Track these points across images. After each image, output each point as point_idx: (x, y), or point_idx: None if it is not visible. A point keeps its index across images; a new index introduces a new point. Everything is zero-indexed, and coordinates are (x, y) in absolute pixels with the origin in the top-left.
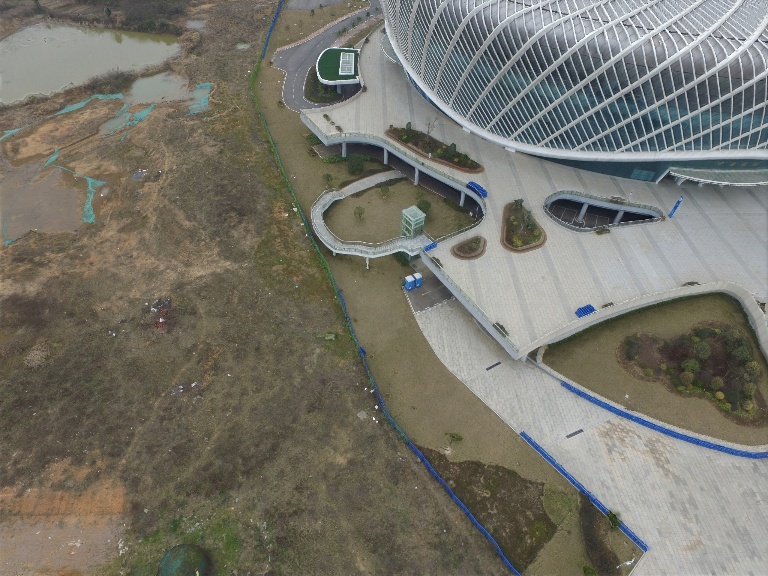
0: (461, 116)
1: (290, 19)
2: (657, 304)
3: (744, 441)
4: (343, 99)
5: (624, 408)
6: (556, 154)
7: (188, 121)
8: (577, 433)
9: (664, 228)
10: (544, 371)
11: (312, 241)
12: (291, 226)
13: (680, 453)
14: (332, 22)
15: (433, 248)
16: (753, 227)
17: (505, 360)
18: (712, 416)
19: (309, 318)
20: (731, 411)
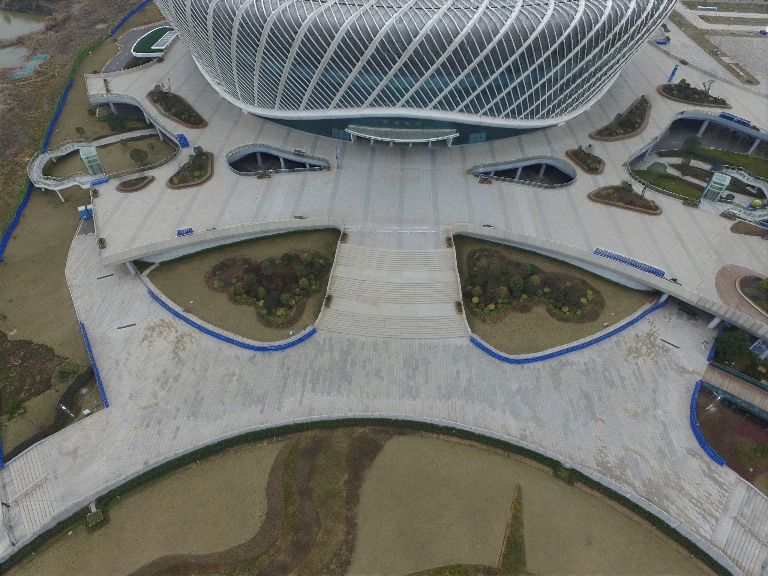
0: None
1: None
2: (272, 235)
3: (258, 338)
4: None
5: (182, 310)
6: (266, 113)
7: (2, 84)
8: (129, 326)
9: (323, 176)
10: (143, 282)
11: None
12: (25, 167)
13: (200, 344)
14: None
15: (104, 183)
16: (405, 179)
17: (119, 273)
18: (247, 319)
19: None
20: (266, 316)
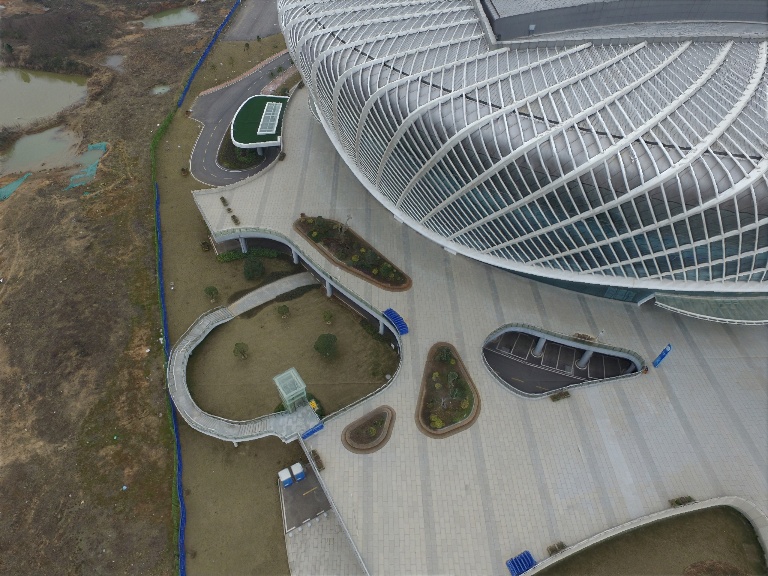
0: (391, 202)
1: (224, 53)
2: None
3: None
4: (263, 163)
5: None
6: (505, 266)
7: (61, 200)
8: None
9: (646, 387)
10: None
11: (167, 400)
12: (148, 370)
13: None
14: (273, 56)
15: (317, 431)
16: None
17: None
18: None
19: (126, 552)
20: None
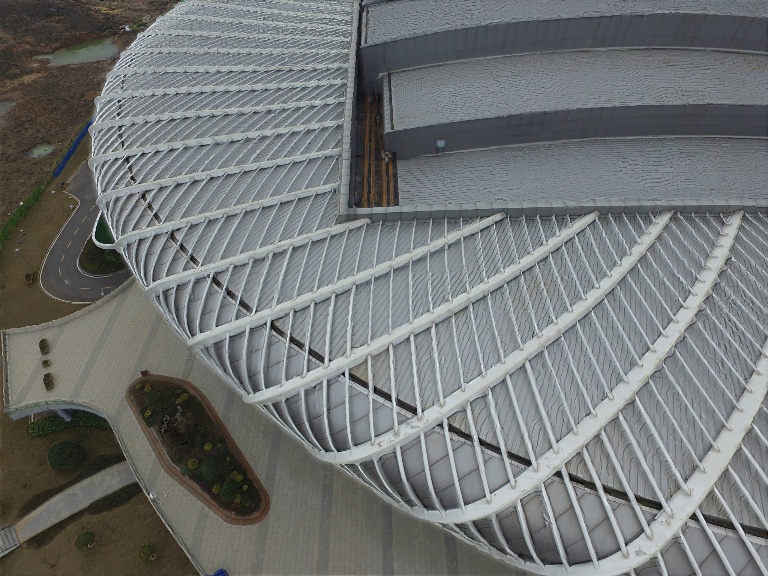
0: None
1: None
2: None
3: None
4: None
5: None
6: None
7: None
8: None
9: None
10: None
11: None
12: None
13: None
14: None
15: None
16: None
17: None
18: None
19: None
20: None
